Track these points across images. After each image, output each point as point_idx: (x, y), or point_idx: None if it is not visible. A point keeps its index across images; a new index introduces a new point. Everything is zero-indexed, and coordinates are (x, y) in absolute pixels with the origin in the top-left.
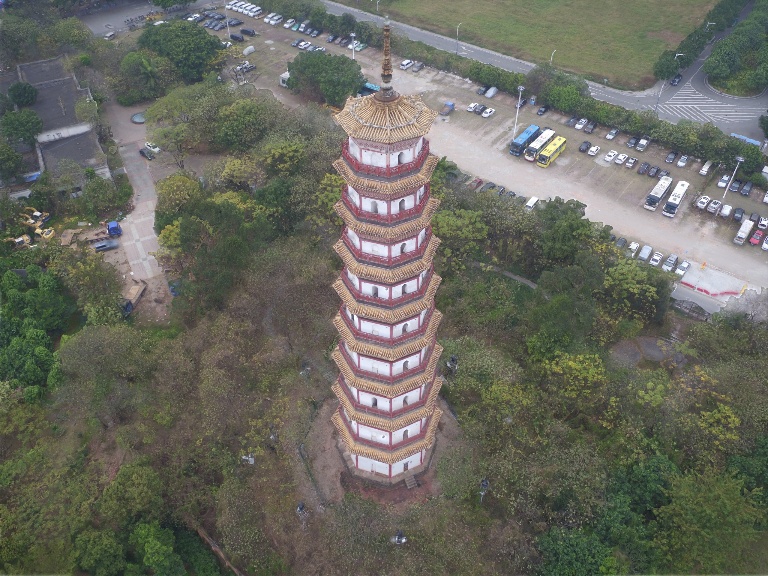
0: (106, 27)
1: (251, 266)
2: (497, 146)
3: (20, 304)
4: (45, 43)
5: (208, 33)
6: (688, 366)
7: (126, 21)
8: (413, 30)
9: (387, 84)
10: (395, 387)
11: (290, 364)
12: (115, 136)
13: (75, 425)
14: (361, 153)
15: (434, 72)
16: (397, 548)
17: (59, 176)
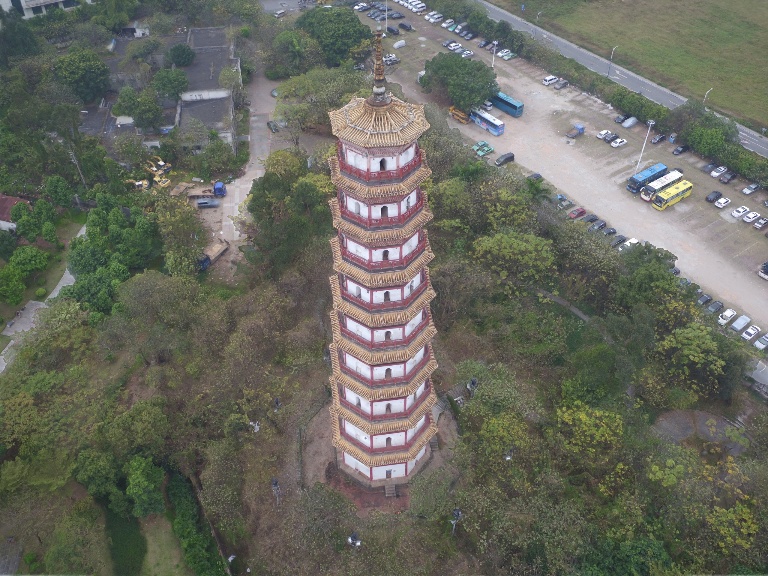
0: (281, 5)
1: (308, 247)
2: (615, 179)
3: (117, 239)
4: (219, 12)
5: None
6: (745, 456)
7: (299, 2)
8: (570, 46)
9: (378, 89)
10: (375, 391)
11: None
12: (252, 106)
13: None
14: (346, 153)
15: (576, 92)
16: (346, 548)
17: (185, 133)
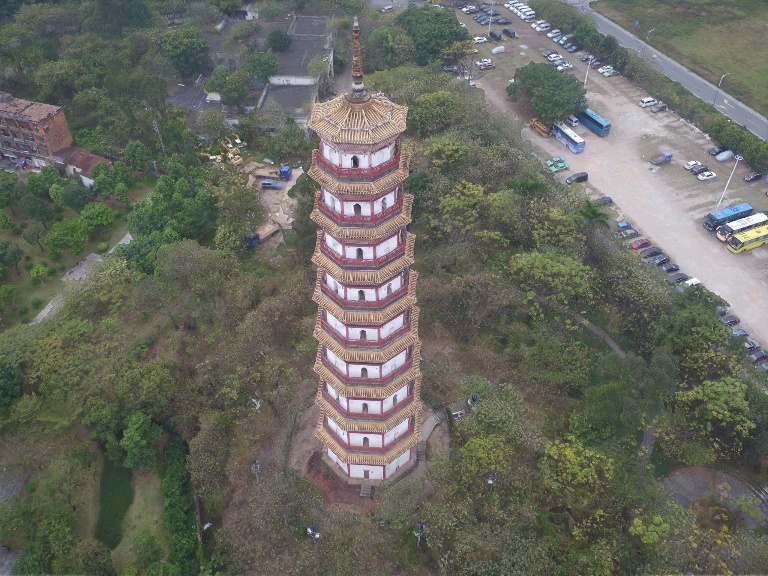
0: (391, 1)
1: None
2: (693, 213)
3: (179, 207)
4: (326, 2)
5: (459, 24)
6: (762, 531)
7: None
8: (680, 69)
9: (356, 85)
10: (349, 388)
11: None
12: None
13: (162, 317)
14: (323, 146)
15: (674, 118)
16: (303, 538)
17: (263, 115)
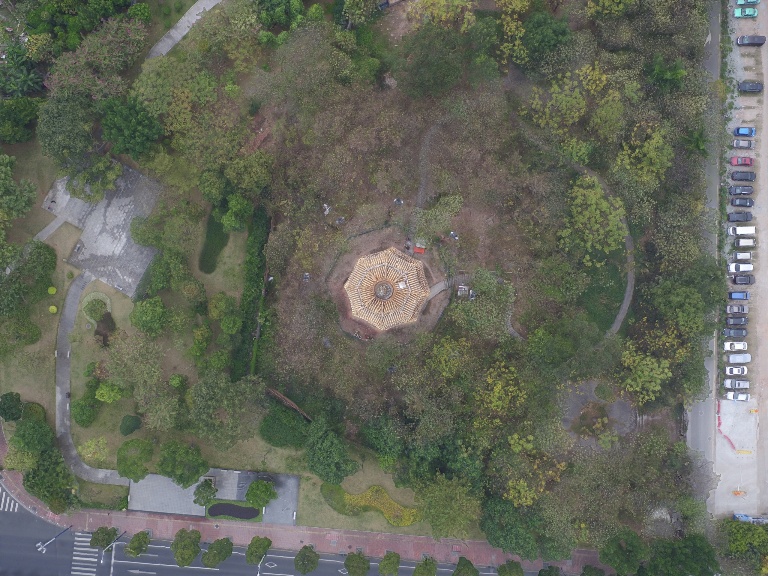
0: None
1: (439, 103)
2: None
3: None
4: None
5: None
6: None
7: None
8: None
9: None
10: None
11: (402, 183)
12: None
13: None
14: None
15: None
16: (318, 347)
17: None
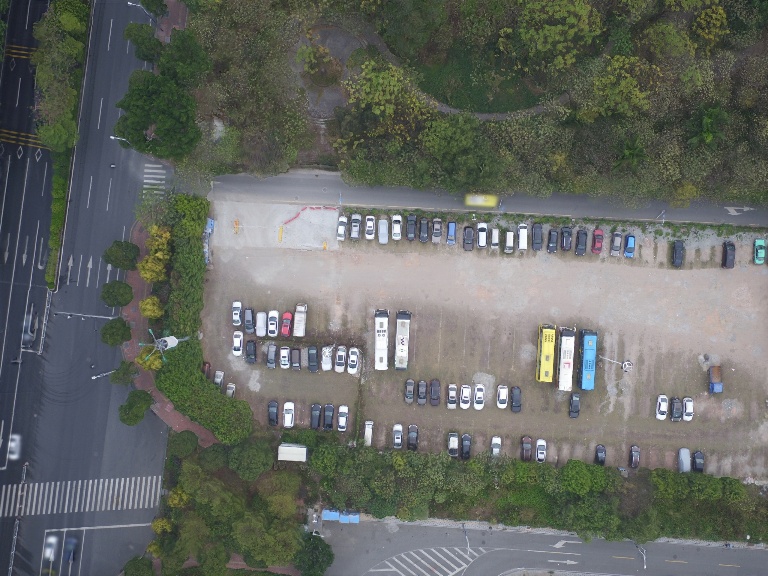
0: None
1: None
2: (614, 338)
3: None
4: None
5: None
6: None
7: None
8: None
9: None
10: None
11: None
12: None
13: None
14: None
15: None
16: None
17: None
